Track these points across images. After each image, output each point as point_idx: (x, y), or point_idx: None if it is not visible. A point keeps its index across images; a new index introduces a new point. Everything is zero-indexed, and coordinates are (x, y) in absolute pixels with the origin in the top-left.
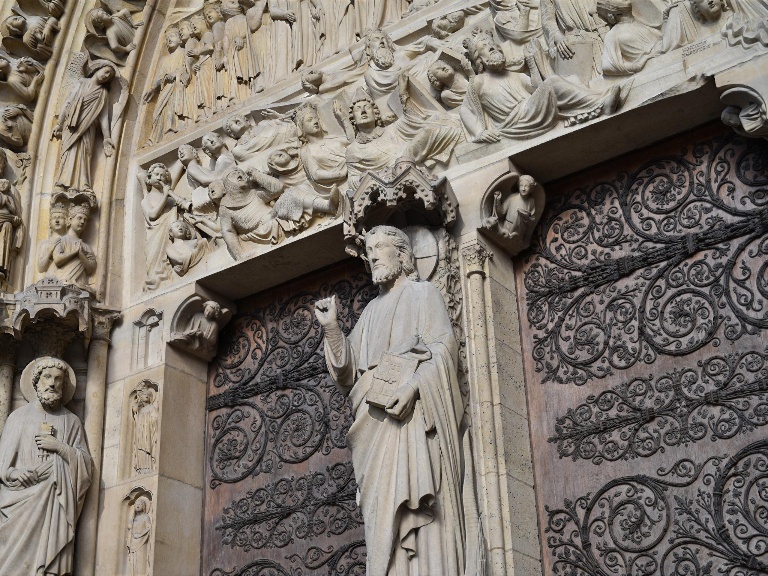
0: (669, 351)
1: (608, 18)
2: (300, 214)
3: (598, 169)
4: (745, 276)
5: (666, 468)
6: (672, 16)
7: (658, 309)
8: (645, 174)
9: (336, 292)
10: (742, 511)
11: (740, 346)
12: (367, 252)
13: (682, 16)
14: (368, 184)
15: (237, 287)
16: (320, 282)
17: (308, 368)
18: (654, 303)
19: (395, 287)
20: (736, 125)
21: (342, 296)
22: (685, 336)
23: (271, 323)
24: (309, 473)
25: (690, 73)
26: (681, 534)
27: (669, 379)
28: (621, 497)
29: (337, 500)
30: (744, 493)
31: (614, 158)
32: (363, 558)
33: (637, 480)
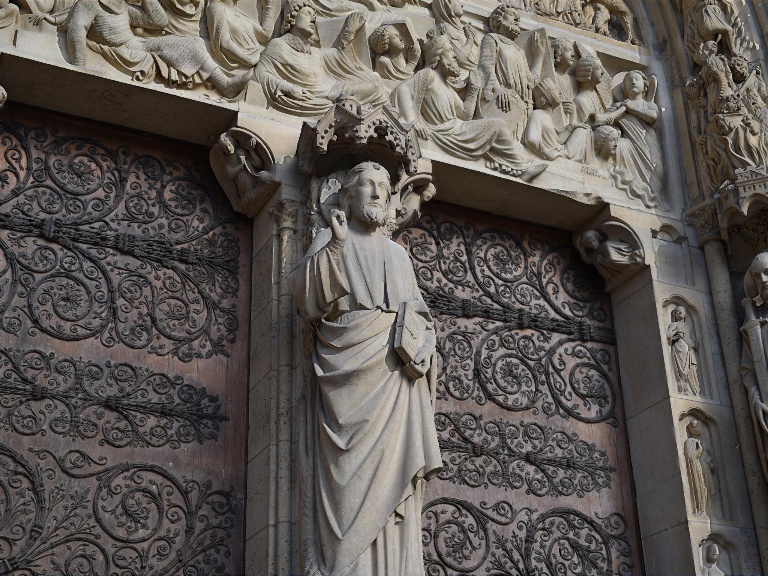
0: (500, 401)
1: (539, 100)
2: (194, 71)
3: (450, 208)
4: (562, 367)
5: (488, 503)
6: (581, 134)
7: (492, 360)
8: (489, 237)
9: (141, 165)
10: (547, 562)
11: (554, 423)
12: (365, 183)
13: (588, 139)
14: (378, 116)
15: (23, 86)
16: (119, 141)
17: (94, 233)
18: (489, 353)
19: (377, 233)
20: (590, 247)
21: (150, 174)
22: (512, 394)
23: (37, 151)
24: (79, 358)
25: (587, 189)
26: (497, 566)
27: (496, 426)
28: (447, 515)
29: (121, 406)
30: (549, 547)
31: (471, 208)
32: (150, 486)
33: (465, 505)
